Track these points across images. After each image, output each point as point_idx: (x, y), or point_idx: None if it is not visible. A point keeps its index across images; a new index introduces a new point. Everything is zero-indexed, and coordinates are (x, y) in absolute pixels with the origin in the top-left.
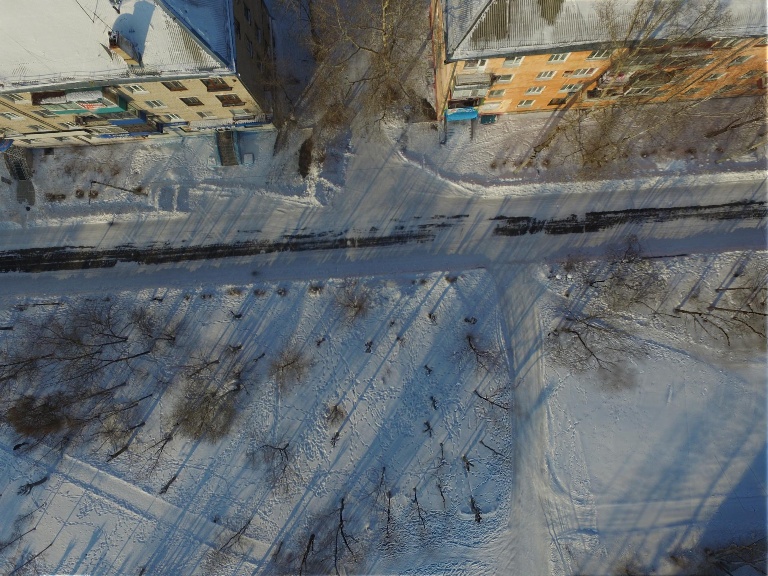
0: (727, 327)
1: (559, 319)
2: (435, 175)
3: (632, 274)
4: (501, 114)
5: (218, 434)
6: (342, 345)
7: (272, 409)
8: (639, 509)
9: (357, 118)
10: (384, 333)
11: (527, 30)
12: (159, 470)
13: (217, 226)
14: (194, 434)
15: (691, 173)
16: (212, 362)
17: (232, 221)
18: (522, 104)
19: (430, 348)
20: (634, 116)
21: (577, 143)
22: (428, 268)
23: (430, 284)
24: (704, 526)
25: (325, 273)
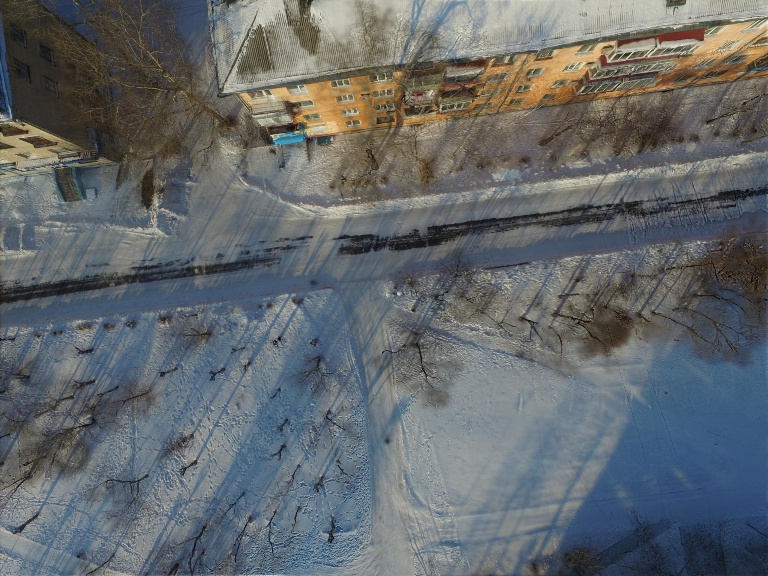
0: (572, 332)
1: (407, 334)
2: (276, 199)
3: (475, 285)
4: (337, 134)
5: (76, 469)
6: (195, 373)
7: (129, 441)
8: (498, 518)
9: (197, 146)
10: (236, 358)
11: (290, 61)
12: (21, 509)
13: (65, 262)
14: (45, 472)
15: (526, 182)
16: (65, 398)
17: (79, 256)
18: (351, 124)
19: (282, 371)
20: (468, 128)
21: (414, 159)
22: (275, 291)
23: (278, 307)
24: (563, 531)
25: (174, 302)
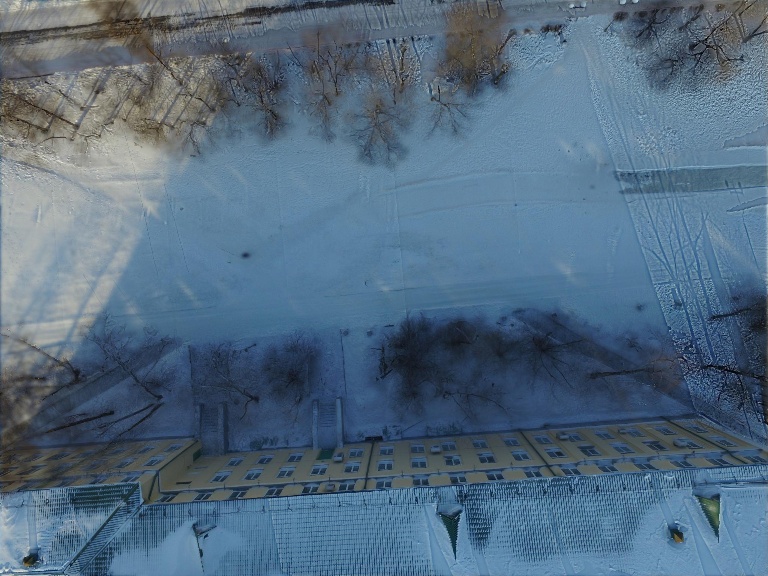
0: (92, 145)
1: None
2: None
3: None
4: None
5: None
6: None
7: None
8: (16, 332)
9: None
10: None
11: None
12: None
13: None
14: None
15: None
16: None
17: None
18: None
19: None
20: None
21: None
22: None
23: None
24: (77, 346)
25: None
